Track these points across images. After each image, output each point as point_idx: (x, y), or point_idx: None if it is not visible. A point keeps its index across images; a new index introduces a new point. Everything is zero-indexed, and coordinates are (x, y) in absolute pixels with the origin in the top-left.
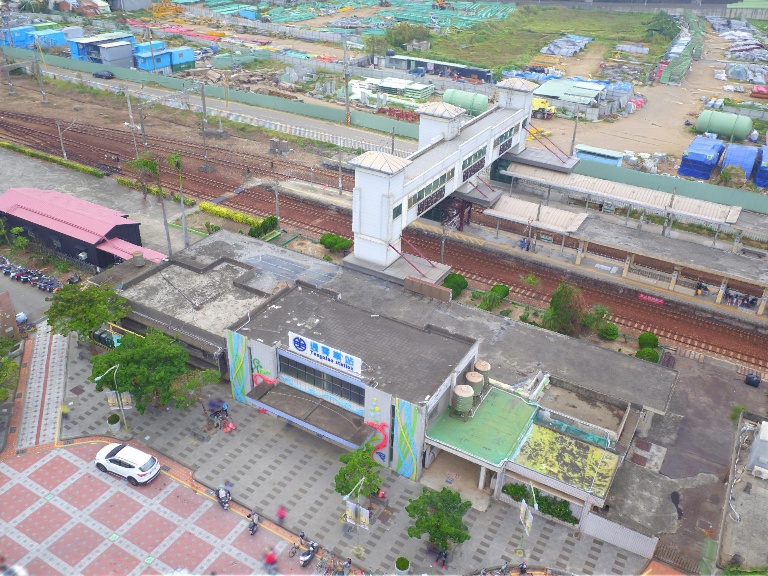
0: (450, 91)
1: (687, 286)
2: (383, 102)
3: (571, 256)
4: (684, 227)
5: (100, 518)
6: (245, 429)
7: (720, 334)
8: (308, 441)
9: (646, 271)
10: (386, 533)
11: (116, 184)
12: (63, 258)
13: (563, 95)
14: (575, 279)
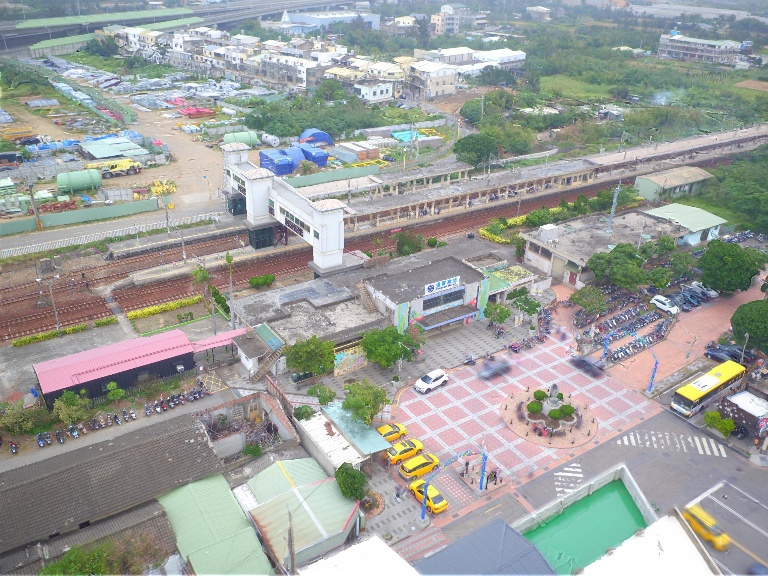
0: (64, 175)
1: (404, 217)
2: (16, 204)
3: (345, 230)
4: (341, 198)
5: (461, 397)
6: (423, 349)
7: (433, 229)
8: (443, 335)
9: (386, 218)
10: (510, 331)
11: (15, 348)
12: (159, 383)
13: (121, 152)
14: (361, 239)
